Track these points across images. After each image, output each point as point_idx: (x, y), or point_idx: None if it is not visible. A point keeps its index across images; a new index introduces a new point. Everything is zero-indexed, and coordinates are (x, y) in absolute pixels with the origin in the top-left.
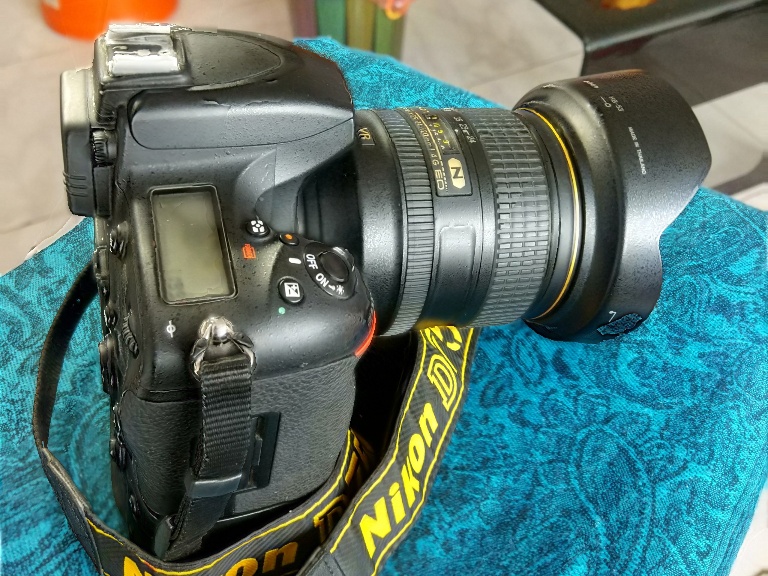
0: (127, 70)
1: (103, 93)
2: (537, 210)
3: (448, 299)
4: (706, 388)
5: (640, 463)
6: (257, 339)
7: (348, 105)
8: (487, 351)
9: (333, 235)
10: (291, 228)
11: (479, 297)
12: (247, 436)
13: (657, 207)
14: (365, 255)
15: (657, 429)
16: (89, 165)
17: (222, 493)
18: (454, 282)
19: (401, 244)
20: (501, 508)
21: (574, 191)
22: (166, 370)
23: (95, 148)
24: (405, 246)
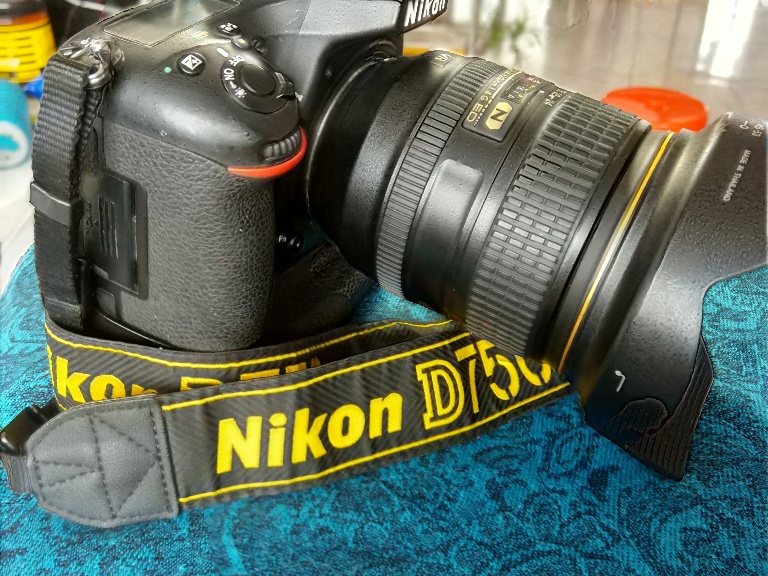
0: None
1: None
2: (571, 193)
3: (434, 252)
4: None
5: None
6: (133, 81)
7: None
8: (536, 422)
9: (350, 125)
10: (303, 88)
11: (468, 269)
12: (68, 149)
13: (722, 247)
14: (362, 152)
15: None
16: None
17: (53, 217)
18: (442, 231)
19: (398, 155)
20: (384, 541)
21: (635, 198)
22: None
23: None
24: (401, 159)
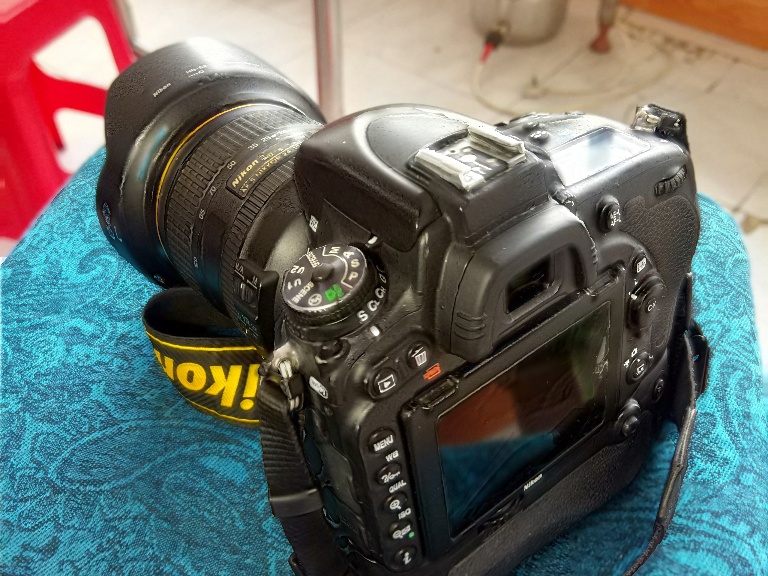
0: None
1: None
2: None
3: None
4: None
5: None
6: None
7: None
8: None
9: None
10: None
11: None
12: None
13: None
14: None
15: None
16: None
17: None
18: None
19: None
20: None
21: None
22: None
23: None
24: None
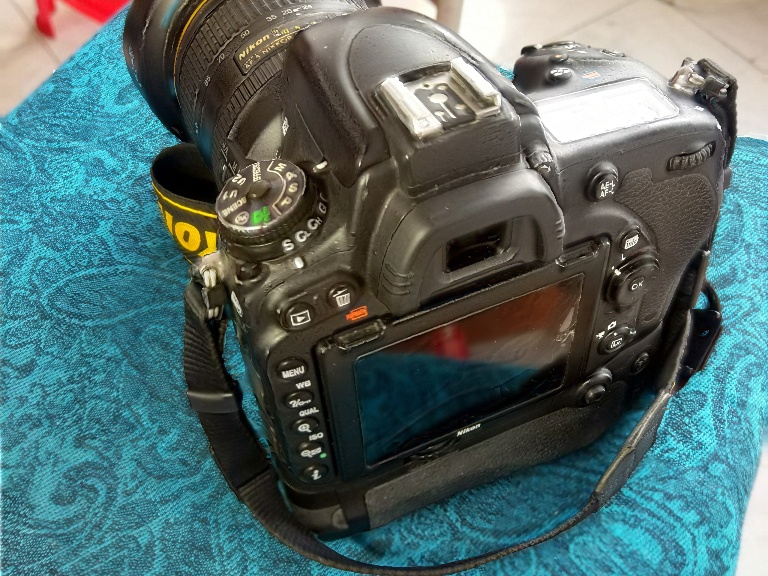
0: None
1: None
2: None
3: None
4: None
5: None
6: None
7: None
8: None
9: None
10: None
11: None
12: None
13: None
14: None
15: None
16: None
17: None
18: None
19: None
20: None
21: None
22: None
23: None
24: None
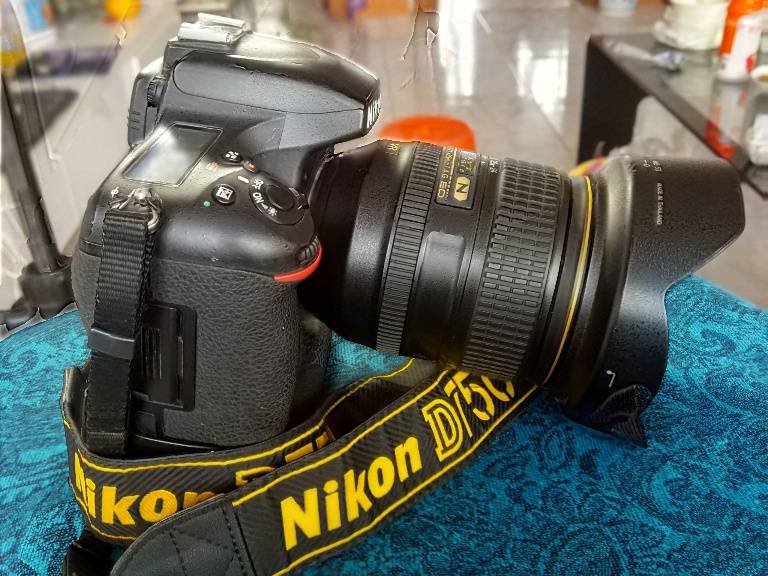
0: (189, 36)
1: (167, 49)
2: (538, 240)
3: (433, 310)
4: (752, 528)
5: (628, 573)
6: (177, 219)
7: (362, 99)
8: (517, 432)
9: (333, 218)
10: None
11: (465, 317)
12: (135, 291)
13: (667, 259)
14: (354, 239)
15: (667, 548)
16: (145, 104)
17: (116, 355)
18: (438, 291)
19: (388, 236)
20: (449, 564)
21: (586, 234)
22: (99, 223)
23: (149, 88)
24: (392, 239)
